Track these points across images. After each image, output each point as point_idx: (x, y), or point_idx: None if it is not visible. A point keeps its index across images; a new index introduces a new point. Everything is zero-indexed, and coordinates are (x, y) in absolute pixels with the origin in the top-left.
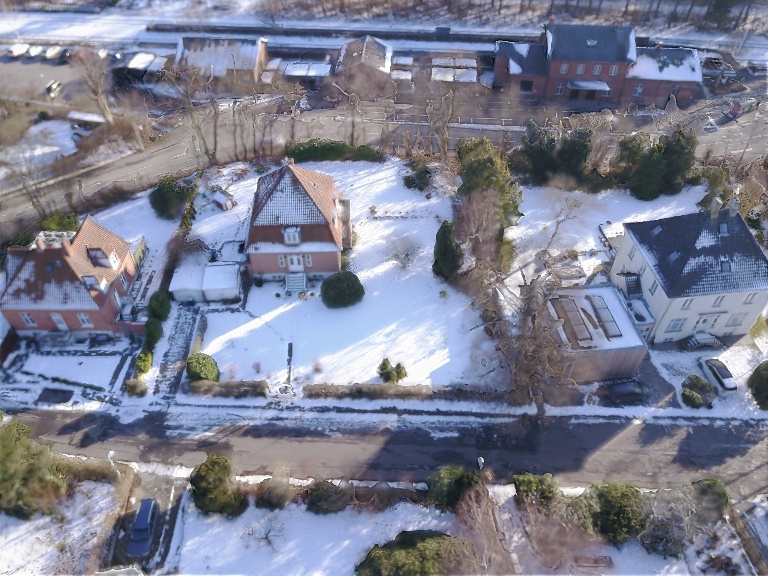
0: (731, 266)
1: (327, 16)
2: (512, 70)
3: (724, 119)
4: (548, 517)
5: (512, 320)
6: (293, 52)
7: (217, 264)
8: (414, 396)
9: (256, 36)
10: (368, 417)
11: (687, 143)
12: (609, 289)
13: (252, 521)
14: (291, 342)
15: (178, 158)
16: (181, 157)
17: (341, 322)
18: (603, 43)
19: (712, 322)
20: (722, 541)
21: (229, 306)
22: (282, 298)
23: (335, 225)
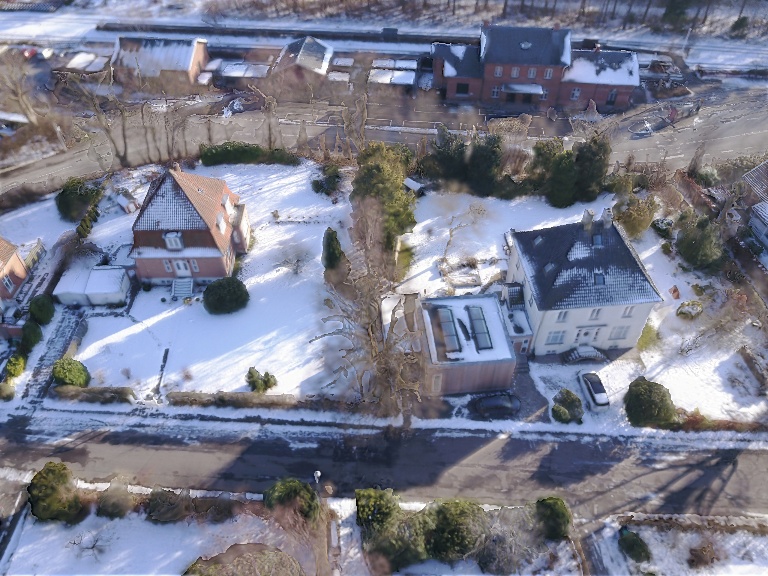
0: (605, 279)
1: (280, 16)
2: (446, 72)
3: (661, 124)
4: (381, 533)
5: (350, 332)
6: (237, 52)
7: (103, 268)
8: (278, 405)
9: (204, 36)
10: (230, 426)
11: (599, 150)
12: (491, 299)
13: (90, 529)
14: (168, 348)
15: None
16: None
17: (222, 328)
18: (537, 46)
19: (593, 335)
20: (562, 562)
21: (113, 310)
22: (167, 303)
23: (221, 230)
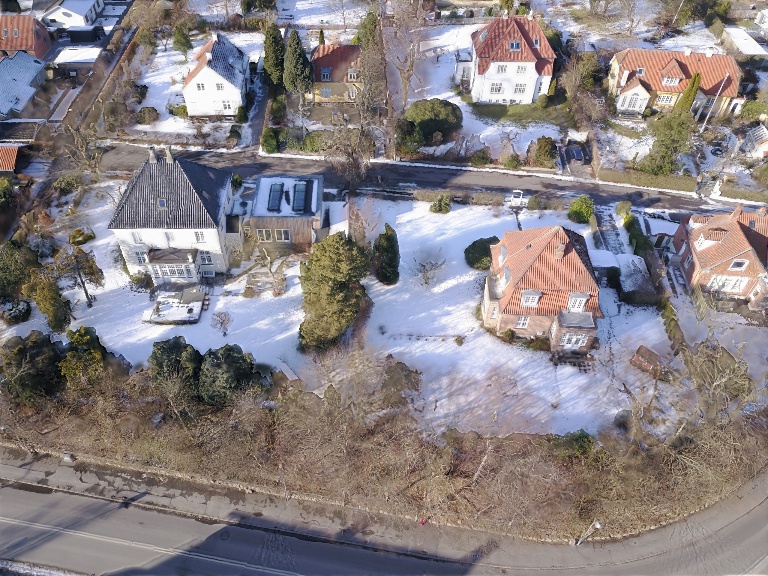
0: None
1: None
2: None
3: None
4: None
5: None
6: None
7: None
8: None
9: None
10: None
11: None
12: None
13: None
14: None
15: None
16: None
17: None
18: None
19: None
20: None
21: None
22: None
23: None
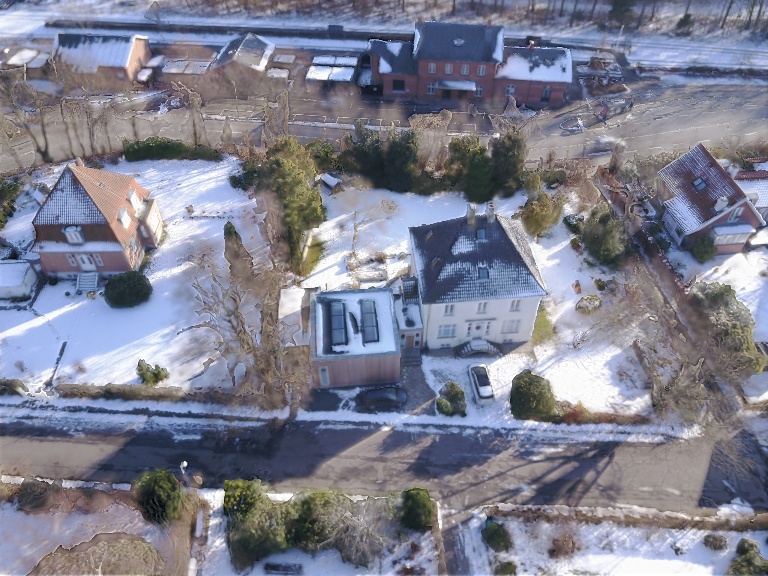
0: (489, 273)
1: (230, 13)
2: (382, 69)
3: (593, 121)
4: (243, 523)
5: (215, 324)
6: (182, 49)
7: (8, 262)
8: (165, 398)
9: (152, 33)
10: (118, 418)
11: (513, 146)
12: (385, 293)
13: None
14: (66, 341)
15: (28, 155)
16: (31, 154)
17: (123, 322)
18: (470, 42)
19: (485, 329)
20: (423, 552)
21: (17, 304)
22: (70, 297)
23: (124, 225)
